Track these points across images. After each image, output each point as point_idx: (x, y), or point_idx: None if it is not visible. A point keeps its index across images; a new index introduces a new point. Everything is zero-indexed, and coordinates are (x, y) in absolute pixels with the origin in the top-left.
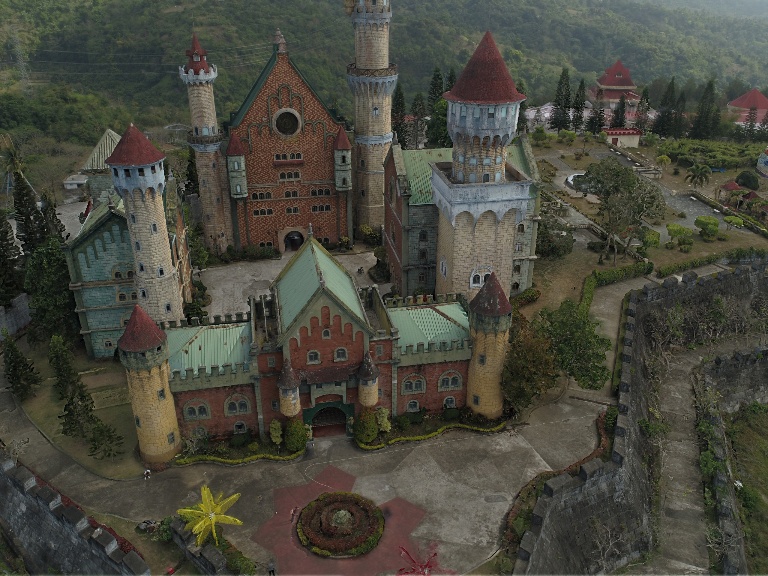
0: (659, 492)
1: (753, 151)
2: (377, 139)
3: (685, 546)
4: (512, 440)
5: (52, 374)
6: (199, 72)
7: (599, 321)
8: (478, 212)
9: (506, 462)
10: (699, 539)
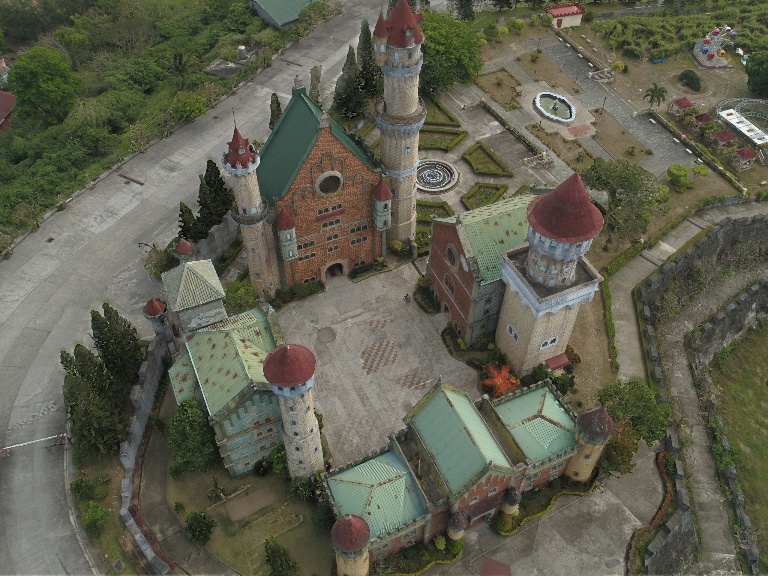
0: (691, 488)
1: (689, 31)
2: (408, 172)
3: (718, 537)
4: (604, 497)
5: (207, 502)
6: (248, 166)
7: (621, 326)
8: (557, 310)
9: (608, 523)
10: (725, 528)
